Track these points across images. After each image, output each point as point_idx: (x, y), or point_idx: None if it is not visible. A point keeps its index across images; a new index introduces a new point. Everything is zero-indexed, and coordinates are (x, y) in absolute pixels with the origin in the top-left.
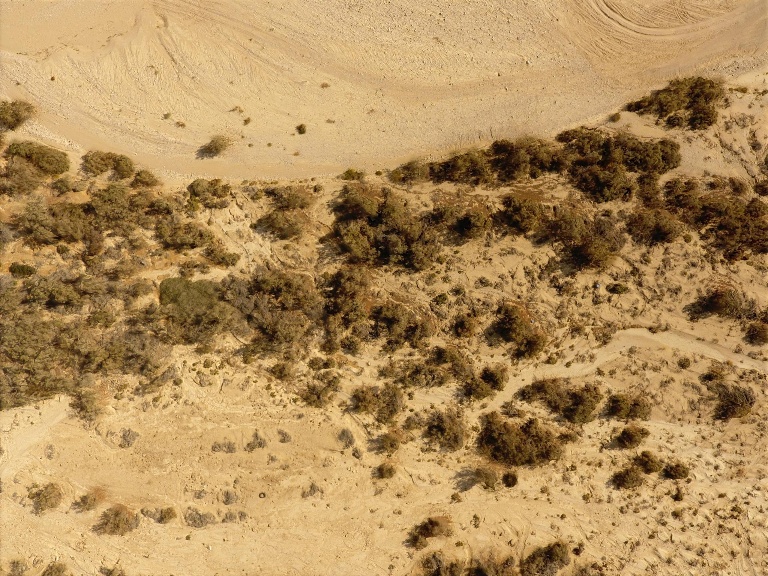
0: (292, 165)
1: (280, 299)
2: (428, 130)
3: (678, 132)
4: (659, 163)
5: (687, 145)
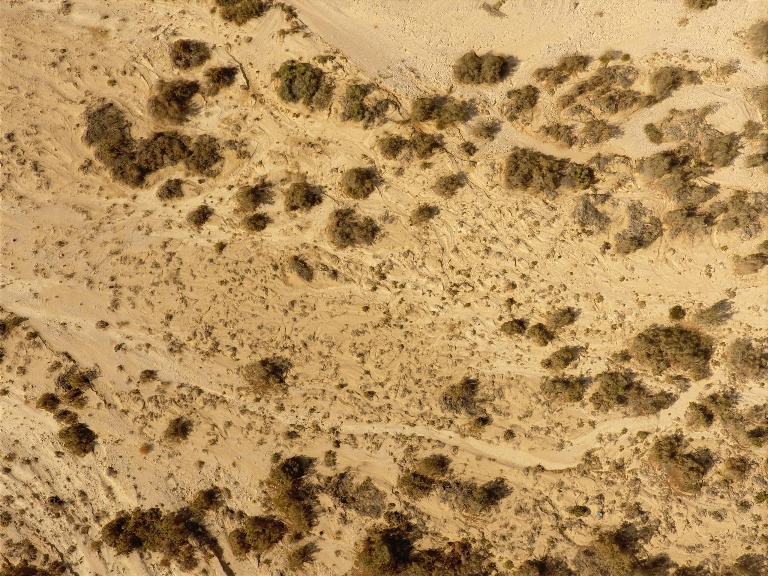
0: None
1: None
2: None
3: None
4: None
5: None
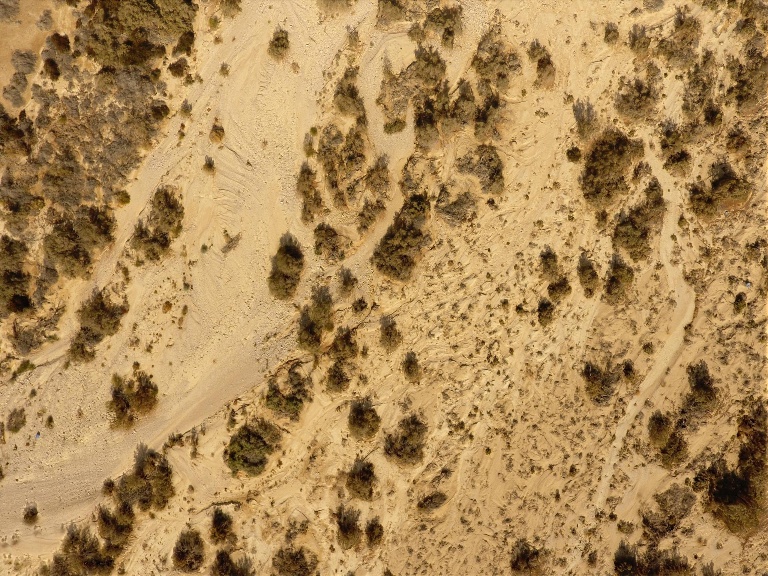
0: None
1: None
2: None
3: None
4: None
5: None
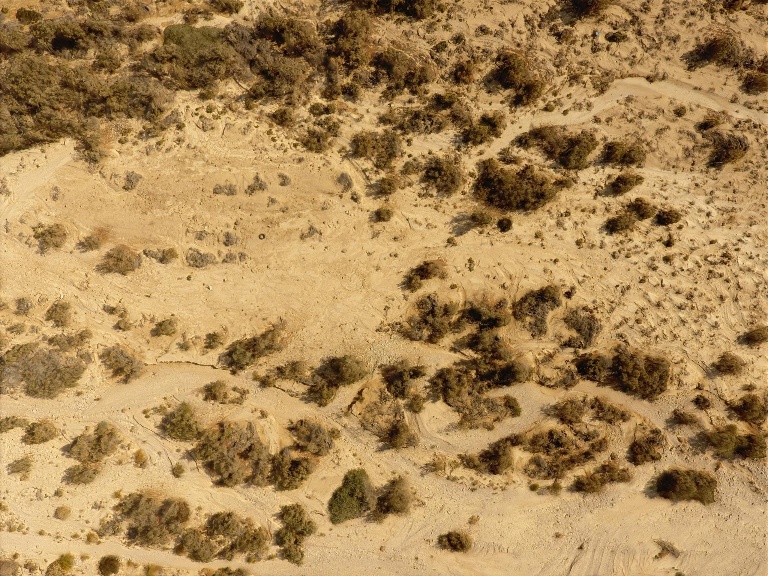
0: None
1: (282, 46)
2: None
3: None
4: None
5: None
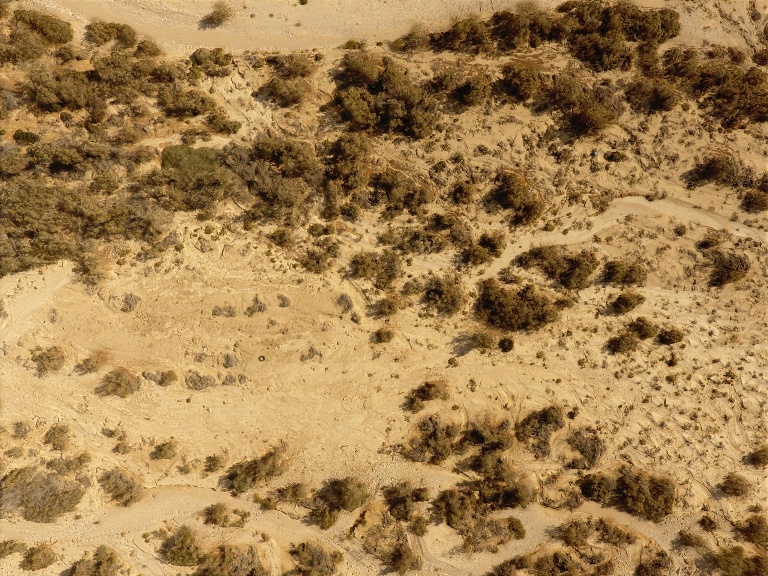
0: (293, 36)
1: (281, 167)
2: (429, 1)
3: (678, 2)
4: (658, 30)
5: (687, 15)
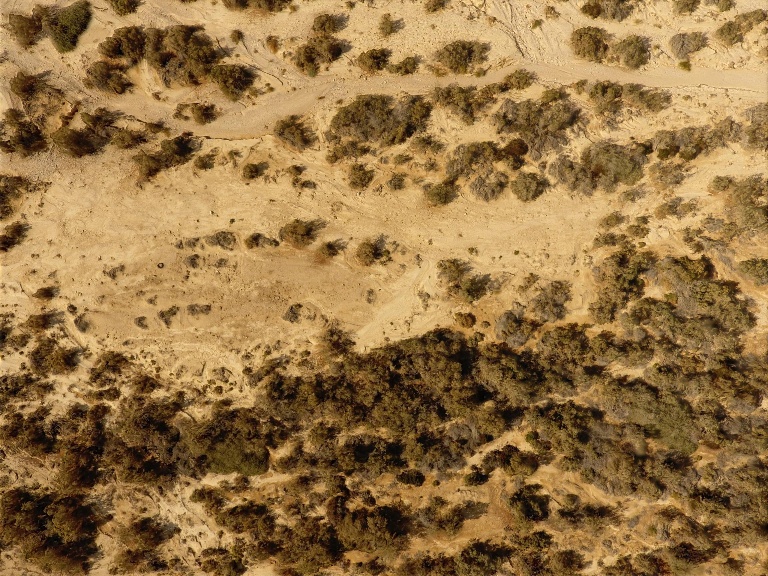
0: None
1: (150, 457)
2: None
3: None
4: None
5: None
